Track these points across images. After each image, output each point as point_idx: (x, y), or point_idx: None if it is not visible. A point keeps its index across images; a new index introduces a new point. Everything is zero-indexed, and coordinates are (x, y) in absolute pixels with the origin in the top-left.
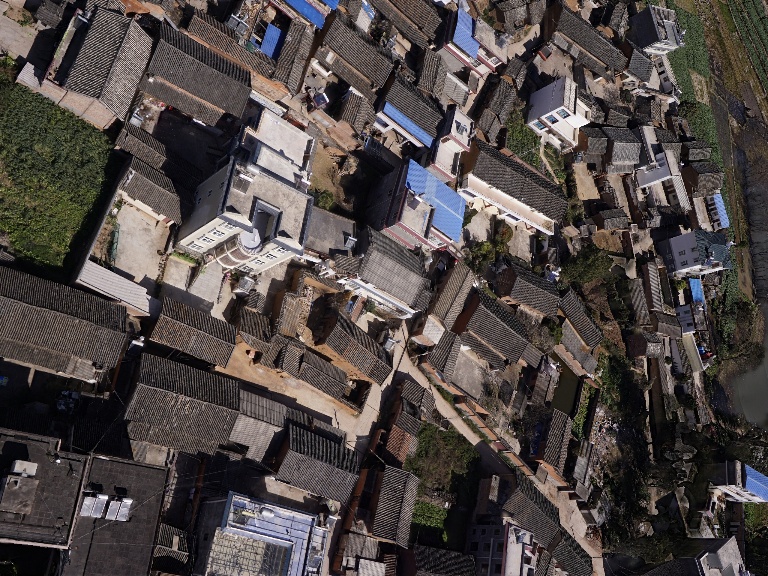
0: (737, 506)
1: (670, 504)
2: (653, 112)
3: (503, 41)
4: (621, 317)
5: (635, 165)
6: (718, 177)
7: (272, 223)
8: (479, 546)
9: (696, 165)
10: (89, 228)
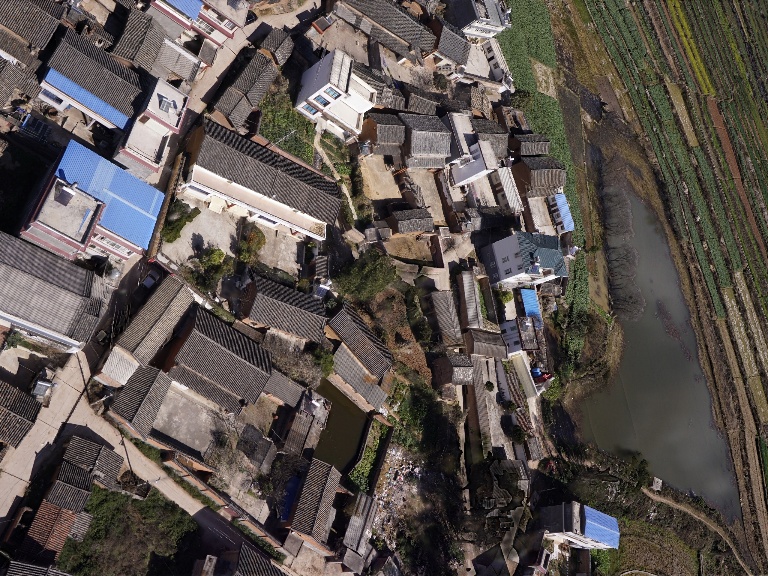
0: (583, 554)
1: (493, 561)
2: (473, 100)
3: None
4: (422, 338)
5: (447, 159)
6: (558, 174)
7: None
8: None
9: (529, 160)
10: None
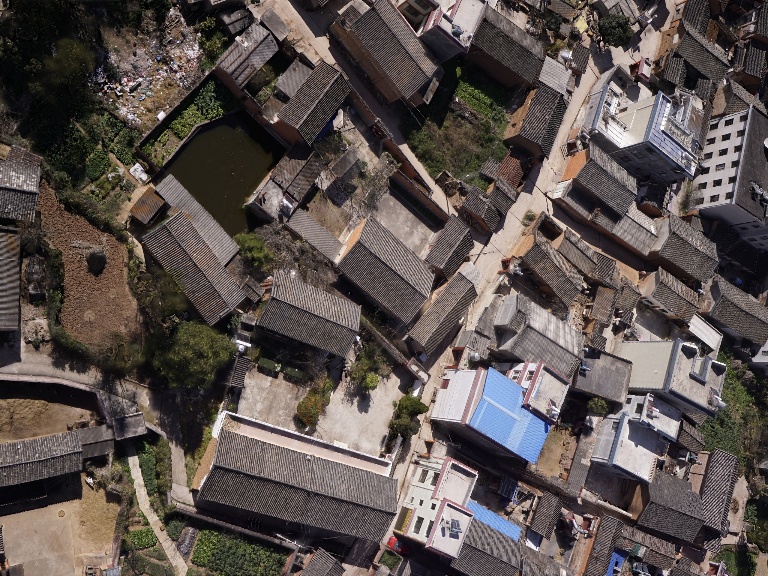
0: None
1: None
2: None
3: None
4: None
5: None
6: None
7: None
8: None
9: None
10: None
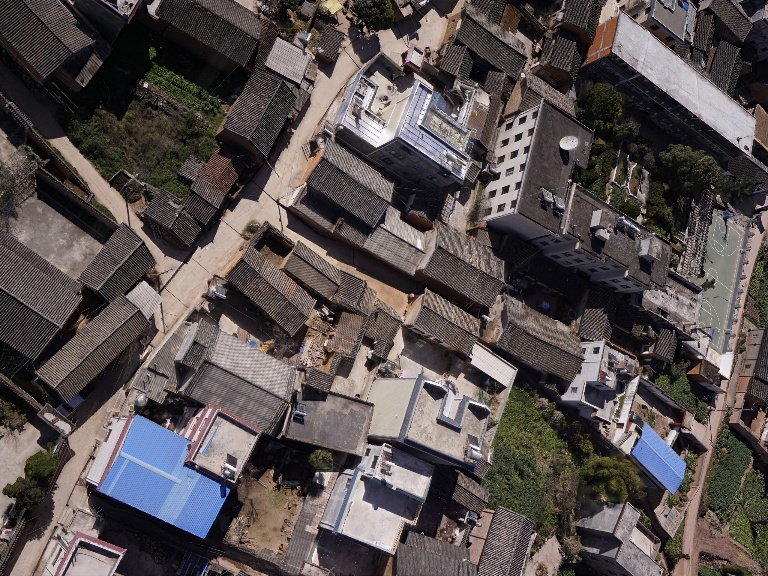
0: None
1: None
2: None
3: None
4: None
5: None
6: None
7: None
8: None
9: None
10: None
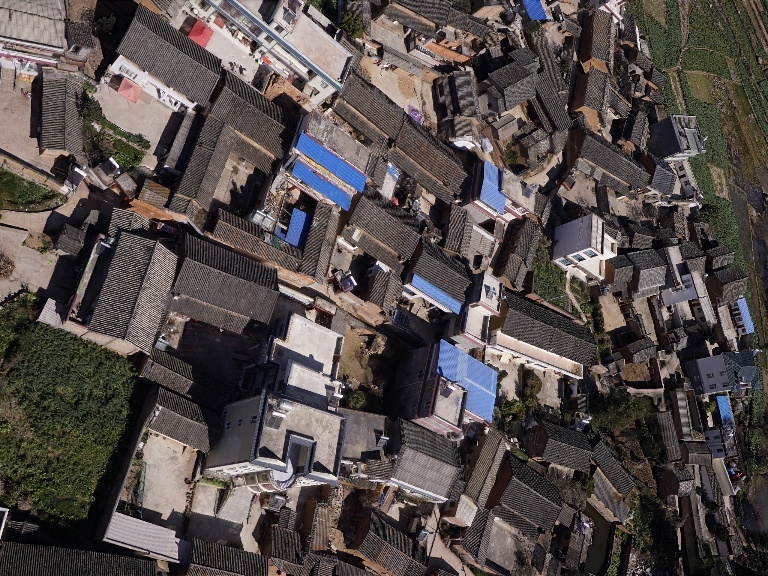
0: None
1: None
2: (676, 225)
3: (530, 191)
4: (652, 455)
5: (661, 286)
6: (742, 283)
7: (305, 453)
8: None
9: (720, 274)
10: (114, 470)
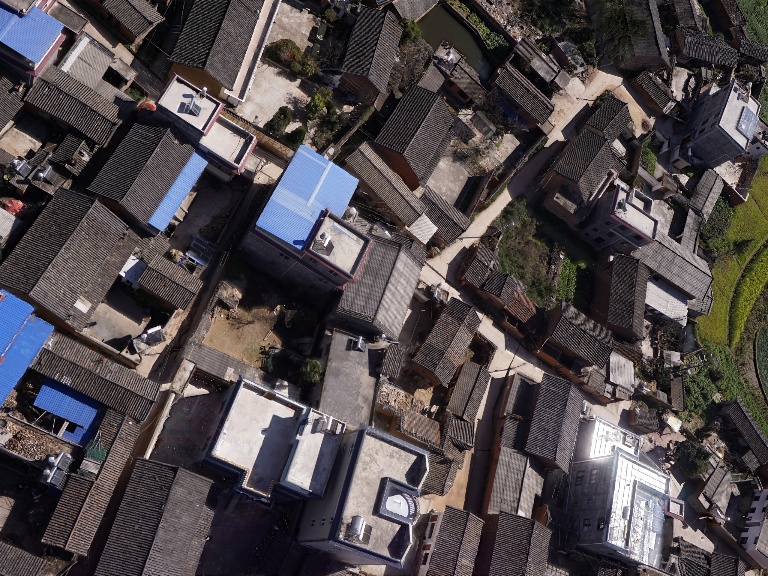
0: None
1: None
2: None
3: None
4: None
5: None
6: None
7: None
8: (603, 238)
9: None
10: None
